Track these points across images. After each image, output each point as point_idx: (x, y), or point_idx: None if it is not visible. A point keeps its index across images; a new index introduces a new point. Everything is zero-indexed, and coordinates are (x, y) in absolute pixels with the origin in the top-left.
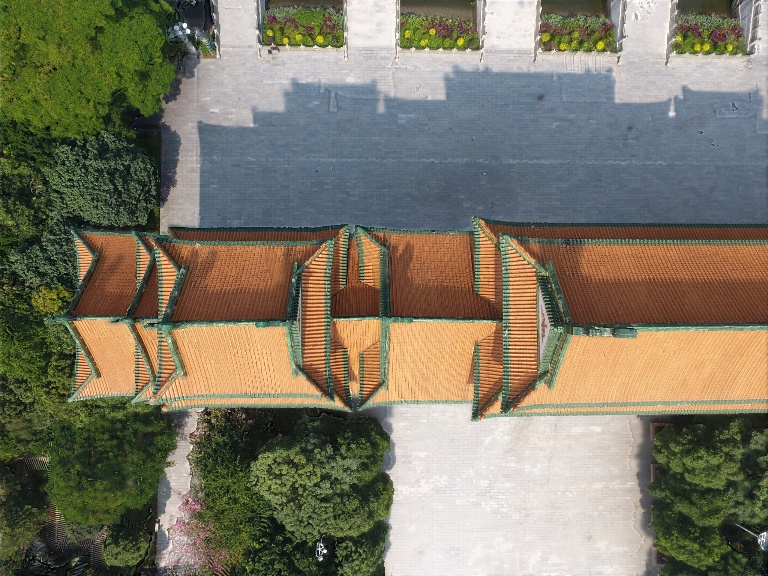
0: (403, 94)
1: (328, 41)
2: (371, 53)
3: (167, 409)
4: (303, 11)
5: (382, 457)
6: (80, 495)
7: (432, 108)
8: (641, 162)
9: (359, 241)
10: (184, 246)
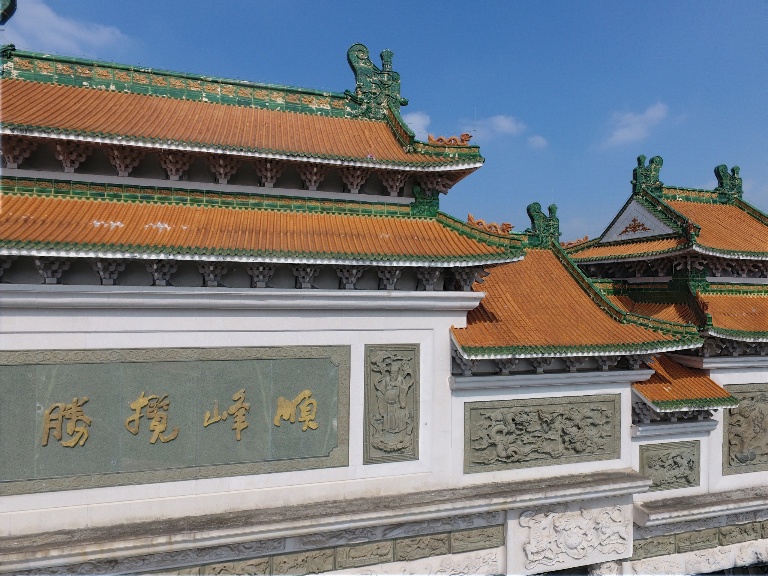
0: None
1: None
2: None
3: None
4: None
5: None
6: None
7: None
8: None
9: None
10: None
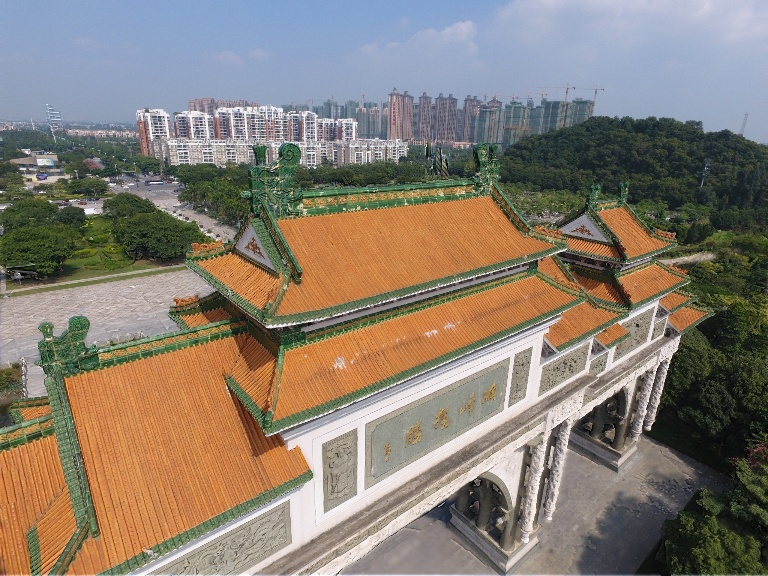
0: None
1: None
2: None
3: None
4: None
5: None
6: None
7: None
8: None
9: (17, 418)
10: None
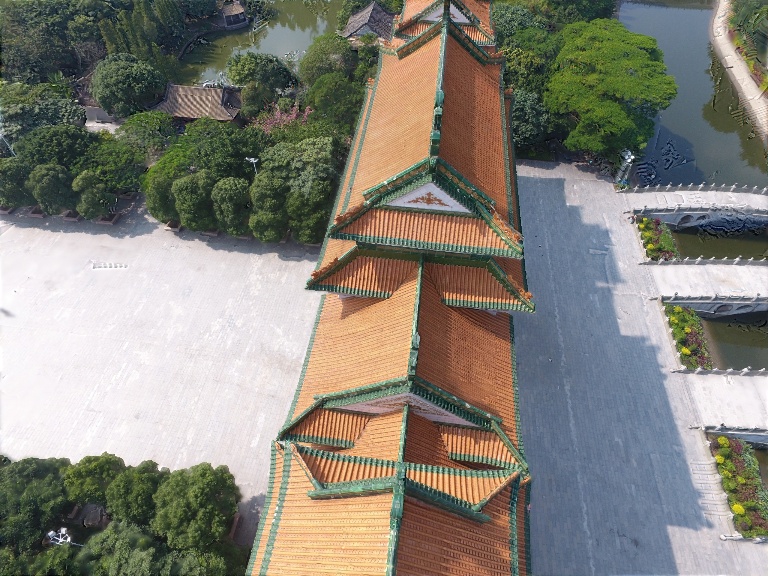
0: (618, 300)
1: (651, 254)
2: (650, 281)
3: (394, 22)
4: (671, 240)
5: (296, 236)
6: (330, 78)
7: (610, 322)
8: (591, 553)
9: None
10: (489, 7)
